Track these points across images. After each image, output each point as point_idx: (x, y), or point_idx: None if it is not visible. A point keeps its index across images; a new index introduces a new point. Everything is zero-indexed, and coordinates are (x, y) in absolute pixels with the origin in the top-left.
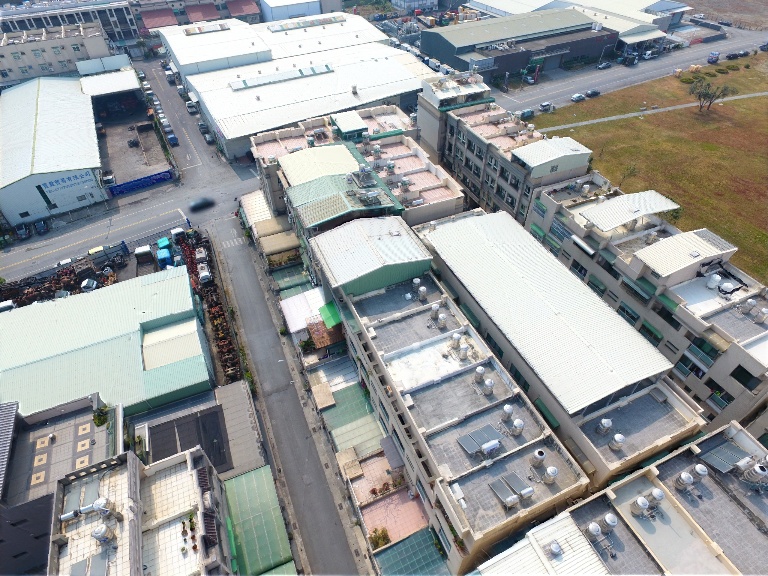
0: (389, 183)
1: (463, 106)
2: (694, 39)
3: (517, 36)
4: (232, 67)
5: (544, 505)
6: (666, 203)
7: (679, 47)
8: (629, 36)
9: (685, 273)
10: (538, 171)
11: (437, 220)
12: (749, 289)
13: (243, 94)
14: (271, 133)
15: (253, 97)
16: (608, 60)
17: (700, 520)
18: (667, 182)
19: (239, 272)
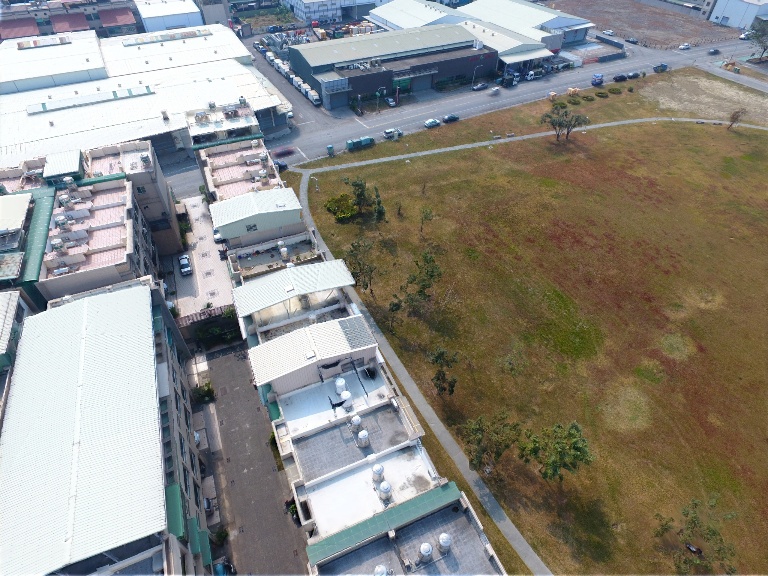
0: (64, 241)
1: (221, 143)
2: (588, 58)
3: (385, 54)
4: (58, 85)
5: None
6: (341, 278)
7: (569, 67)
8: (511, 55)
9: (301, 377)
10: (230, 231)
11: (86, 292)
12: (386, 395)
13: (37, 119)
14: None
15: (47, 122)
16: (487, 80)
17: None
18: (481, 224)
19: None
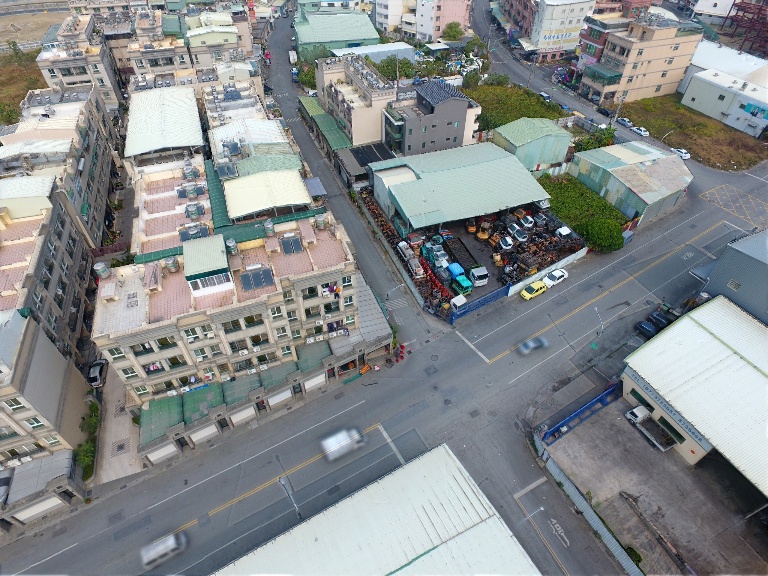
0: None
1: None
2: None
3: None
4: None
5: (222, 88)
6: None
7: None
8: None
9: None
10: None
11: None
12: None
13: None
14: (325, 269)
15: None
16: None
17: None
18: None
19: (379, 270)
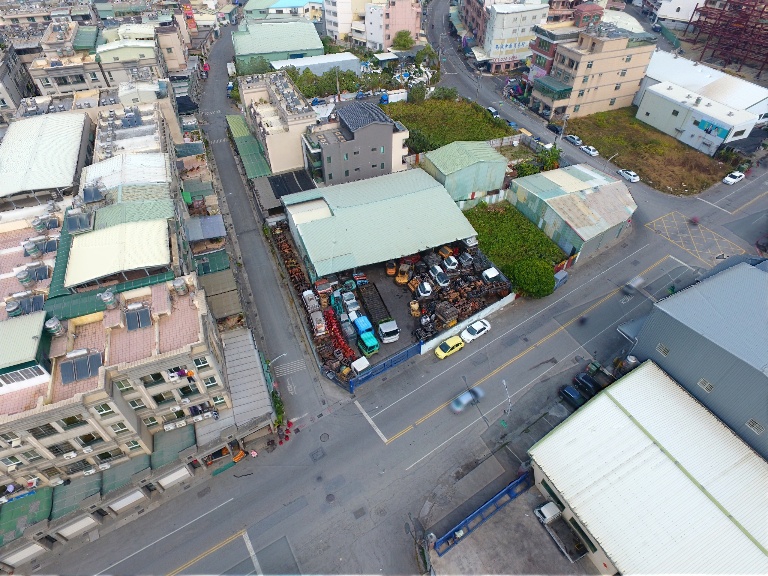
0: None
1: None
2: None
3: None
4: None
5: None
6: None
7: None
8: None
9: None
10: None
11: None
12: None
13: None
14: (165, 353)
15: None
16: None
17: None
18: None
19: (280, 324)
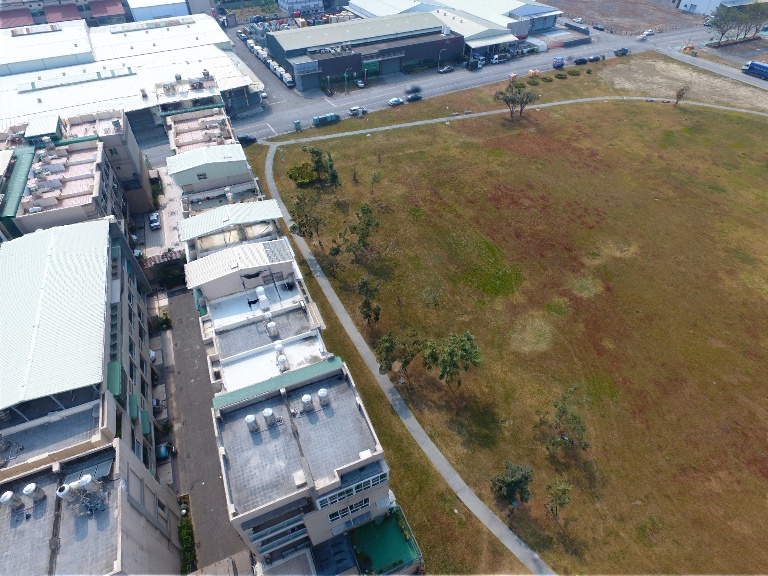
0: None
1: (186, 111)
2: (553, 43)
3: (355, 39)
4: (49, 69)
5: None
6: (272, 213)
7: (535, 51)
8: (476, 40)
9: (227, 285)
10: (182, 178)
11: None
12: None
13: (27, 96)
14: None
15: (36, 99)
16: (454, 64)
17: (4, 541)
18: (428, 189)
19: None
